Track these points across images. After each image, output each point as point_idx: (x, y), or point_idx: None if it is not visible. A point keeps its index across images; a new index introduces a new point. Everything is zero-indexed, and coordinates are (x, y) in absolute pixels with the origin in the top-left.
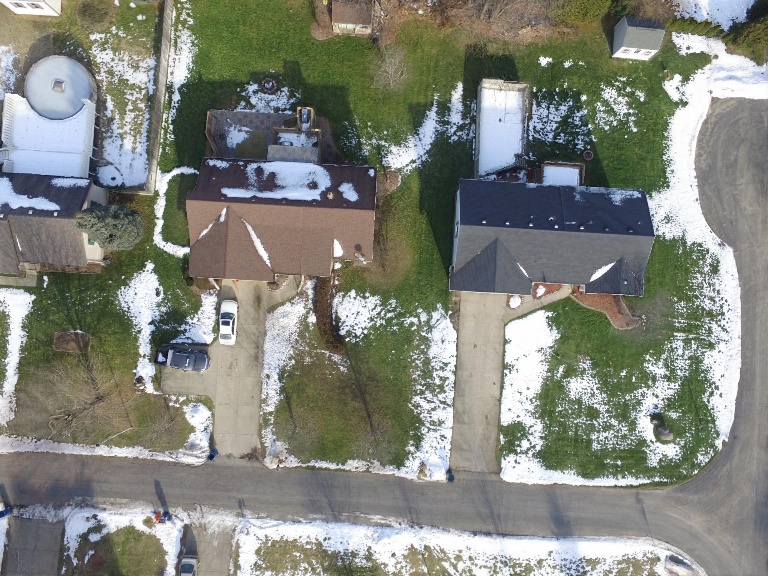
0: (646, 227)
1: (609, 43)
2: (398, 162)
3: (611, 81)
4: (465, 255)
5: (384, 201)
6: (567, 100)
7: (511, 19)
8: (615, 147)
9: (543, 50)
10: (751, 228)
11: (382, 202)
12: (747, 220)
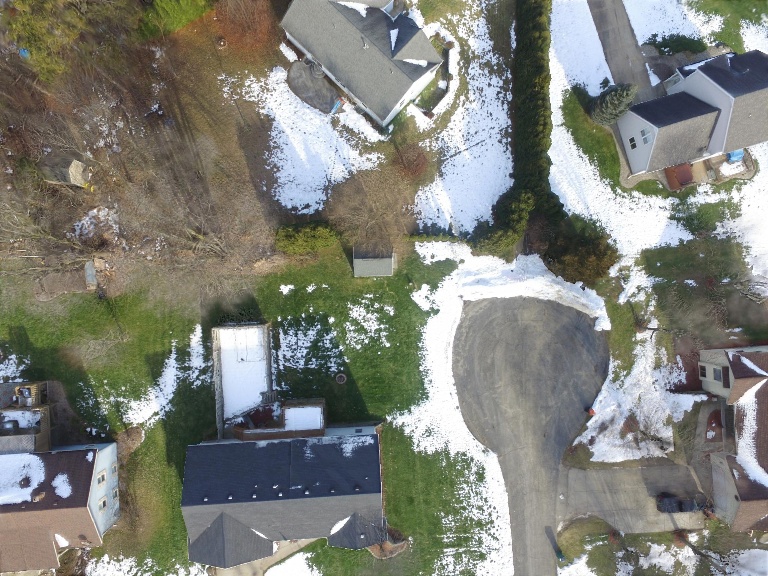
0: (373, 482)
1: (350, 263)
2: (139, 417)
3: (358, 299)
4: (196, 529)
5: (128, 459)
6: (315, 324)
7: (245, 252)
8: (369, 365)
9: (283, 279)
10: (513, 431)
11: (126, 461)
12: (508, 423)
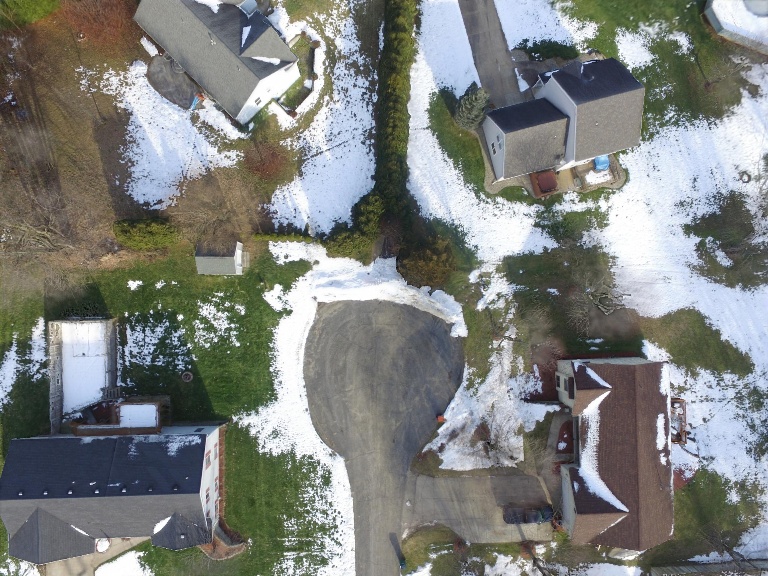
0: (193, 482)
1: None
2: None
3: (208, 297)
4: (13, 523)
5: None
6: (163, 321)
7: (93, 246)
8: (217, 364)
9: (131, 274)
10: (362, 435)
11: None
12: (357, 427)
